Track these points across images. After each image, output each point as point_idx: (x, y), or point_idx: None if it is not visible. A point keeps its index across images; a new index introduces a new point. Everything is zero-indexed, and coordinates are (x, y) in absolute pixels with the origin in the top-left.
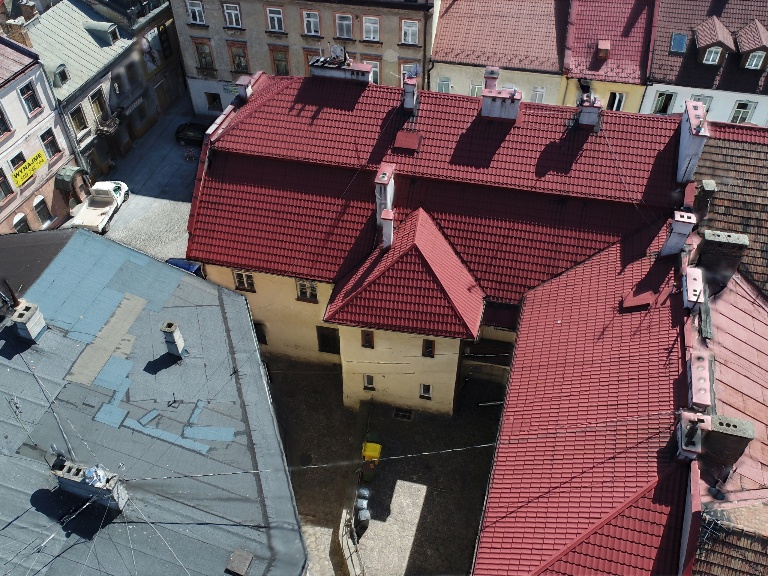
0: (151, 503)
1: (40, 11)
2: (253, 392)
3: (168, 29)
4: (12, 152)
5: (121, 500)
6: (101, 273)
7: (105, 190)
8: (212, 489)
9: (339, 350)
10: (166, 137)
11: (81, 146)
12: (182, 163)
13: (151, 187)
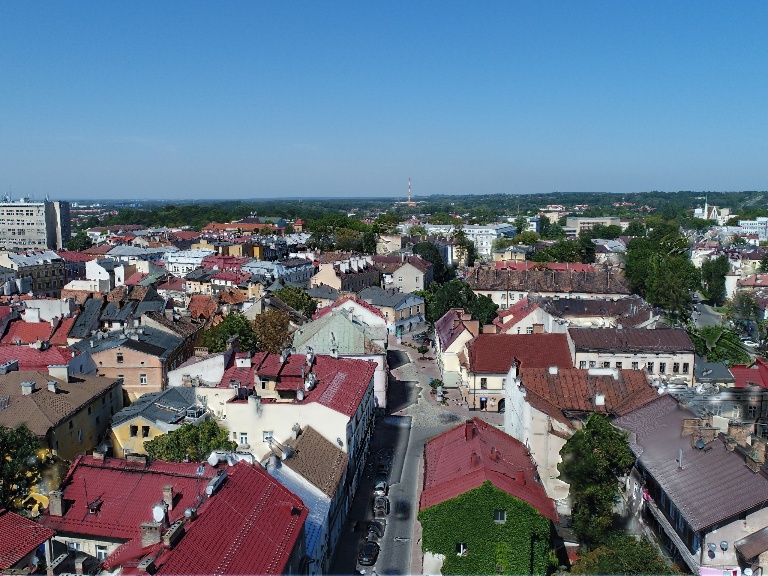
0: None
1: None
2: None
3: None
4: None
5: None
6: None
7: None
8: None
9: None
10: None
11: None
12: None
13: None
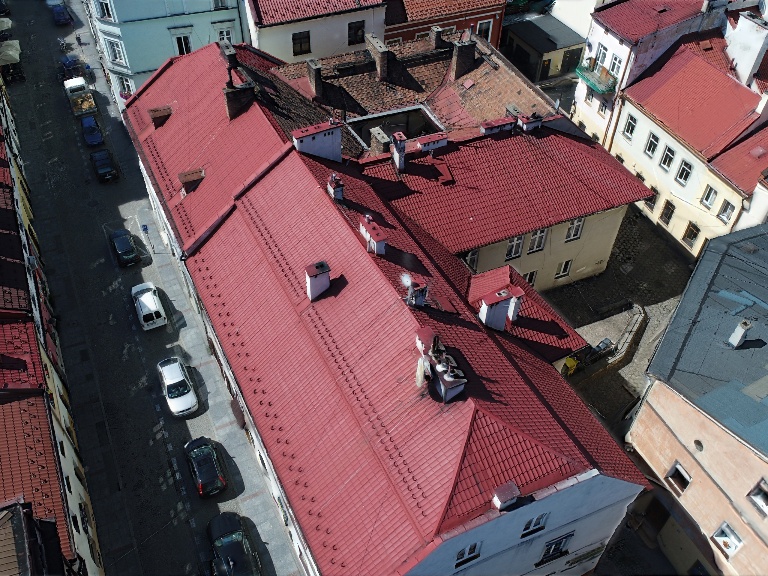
0: None
1: None
2: None
3: None
4: None
5: None
6: None
7: None
8: None
9: None
10: None
11: None
12: None
13: None
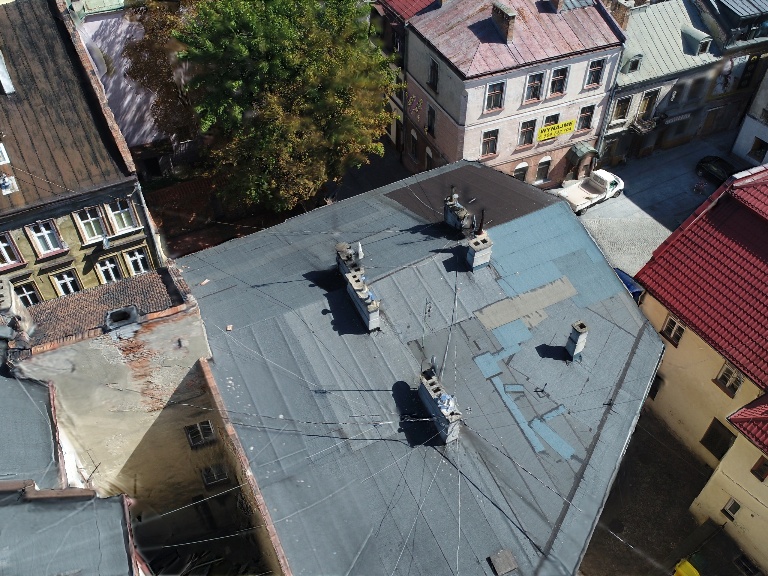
0: (470, 456)
1: (652, 1)
2: (613, 433)
3: (760, 61)
4: (552, 110)
5: (451, 435)
6: (556, 247)
7: (603, 179)
8: (523, 485)
9: (722, 455)
10: (688, 160)
11: (609, 132)
12: (687, 191)
13: (644, 197)
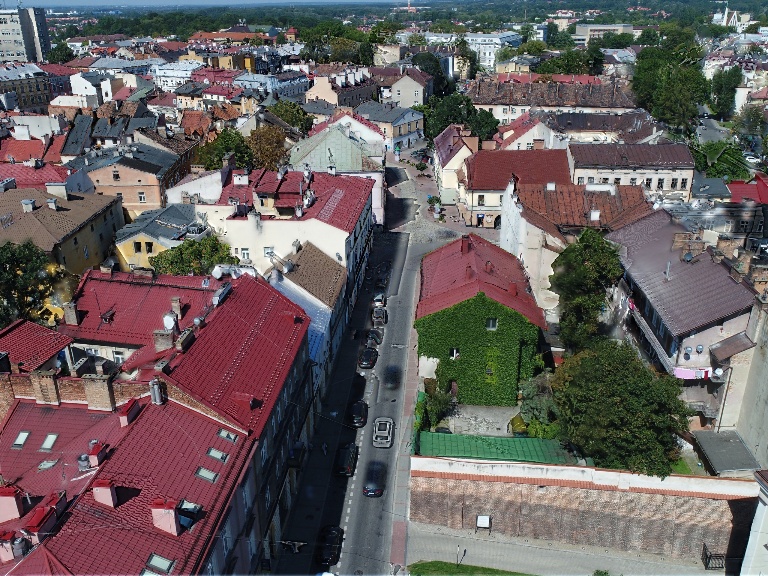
0: None
1: None
2: None
3: None
4: None
5: None
6: None
7: None
8: None
9: None
10: None
11: None
12: None
13: None
